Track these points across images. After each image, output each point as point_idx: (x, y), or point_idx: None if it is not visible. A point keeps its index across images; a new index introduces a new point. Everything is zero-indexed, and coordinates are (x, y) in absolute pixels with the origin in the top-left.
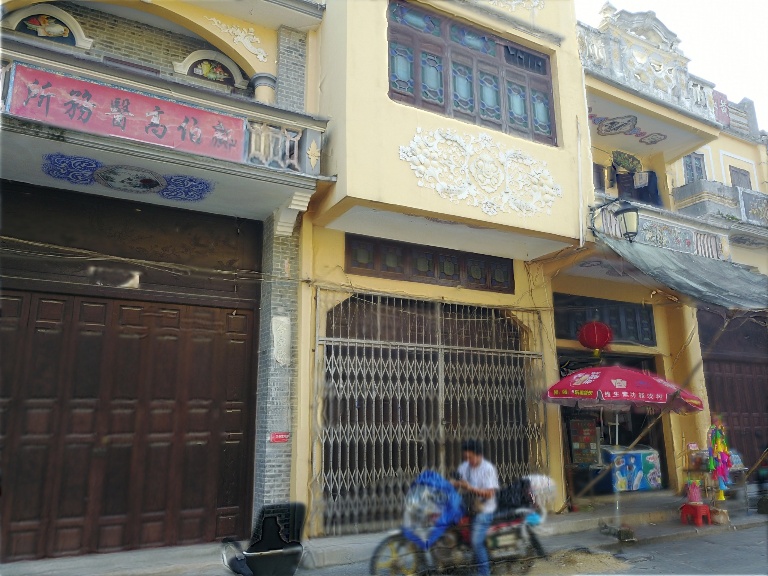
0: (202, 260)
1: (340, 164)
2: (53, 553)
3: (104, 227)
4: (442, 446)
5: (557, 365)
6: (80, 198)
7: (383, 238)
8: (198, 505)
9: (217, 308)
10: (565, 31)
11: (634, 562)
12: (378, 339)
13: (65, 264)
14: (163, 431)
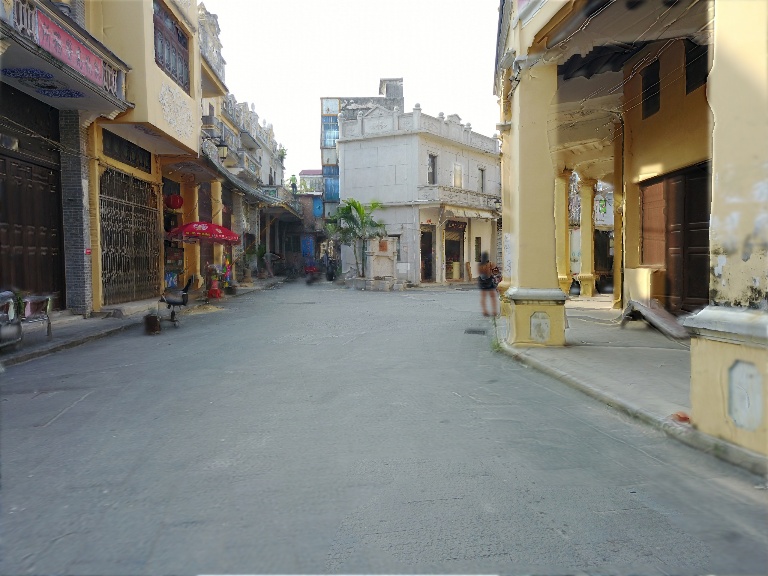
0: None
1: (139, 99)
2: None
3: (1, 104)
4: (133, 259)
5: None
6: None
7: (115, 134)
8: (46, 290)
9: (46, 168)
10: (195, 24)
11: None
12: (115, 197)
13: None
14: (31, 246)
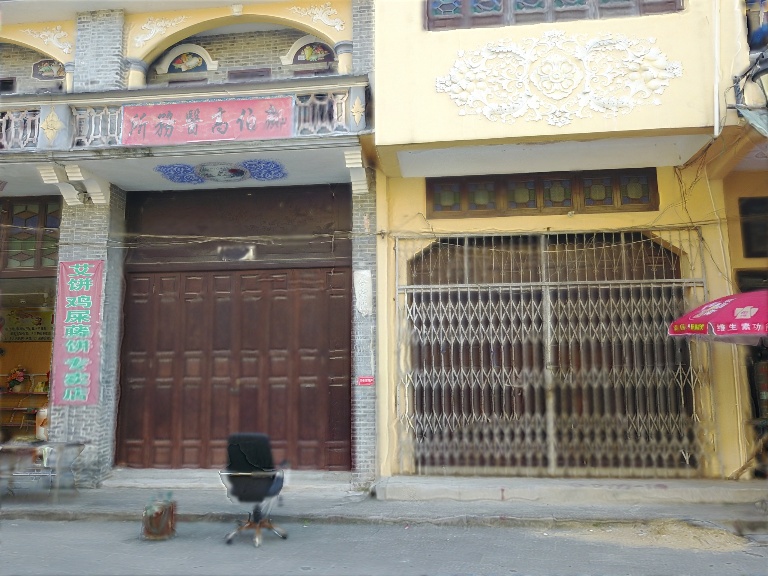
0: (303, 228)
1: None
2: (206, 465)
3: (225, 214)
4: (548, 392)
5: (732, 293)
6: (208, 194)
7: (469, 175)
8: (309, 438)
9: (317, 268)
10: None
11: (757, 546)
12: (465, 282)
13: (200, 248)
14: (278, 376)
